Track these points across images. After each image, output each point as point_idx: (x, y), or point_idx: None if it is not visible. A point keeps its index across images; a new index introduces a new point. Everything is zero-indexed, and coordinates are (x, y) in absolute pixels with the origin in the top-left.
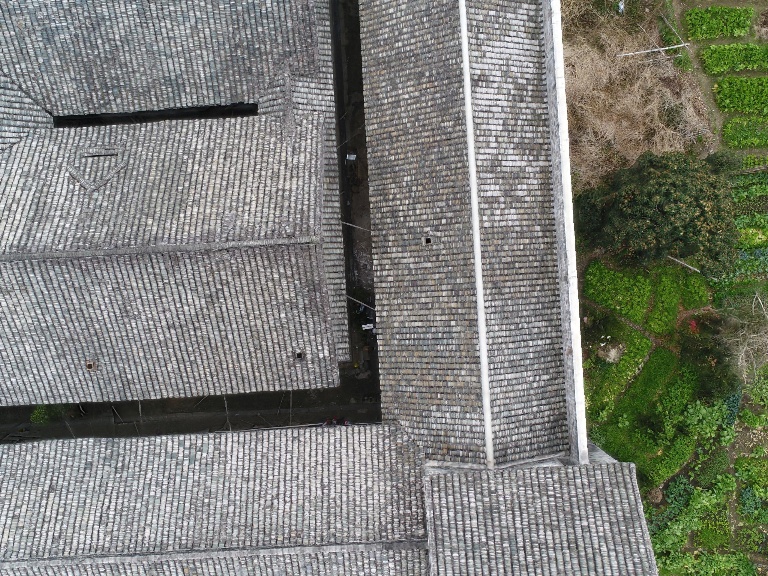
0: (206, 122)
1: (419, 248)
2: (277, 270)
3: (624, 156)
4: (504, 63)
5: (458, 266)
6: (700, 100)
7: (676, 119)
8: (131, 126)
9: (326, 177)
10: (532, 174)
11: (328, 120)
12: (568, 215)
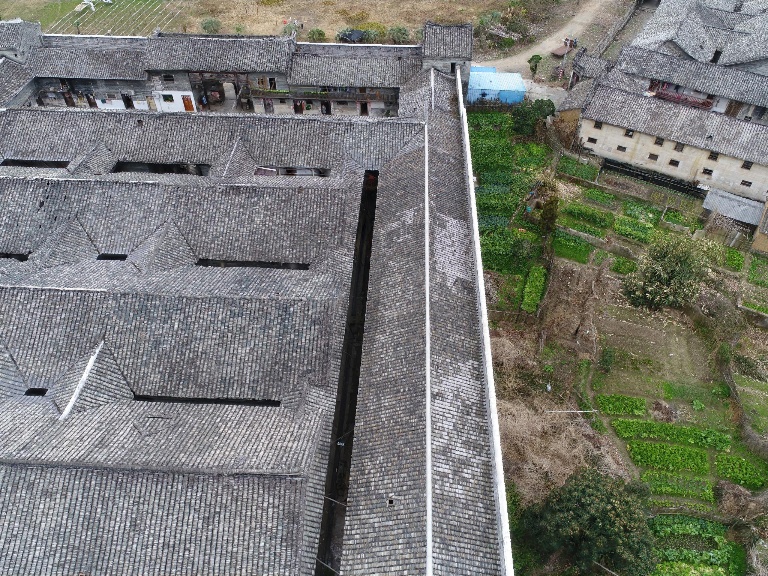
0: (241, 407)
1: (384, 509)
2: (267, 500)
3: (560, 486)
4: (455, 389)
5: (413, 523)
6: (617, 454)
7: (598, 463)
8: (188, 404)
9: (319, 454)
10: (476, 464)
11: (328, 416)
12: (501, 488)
